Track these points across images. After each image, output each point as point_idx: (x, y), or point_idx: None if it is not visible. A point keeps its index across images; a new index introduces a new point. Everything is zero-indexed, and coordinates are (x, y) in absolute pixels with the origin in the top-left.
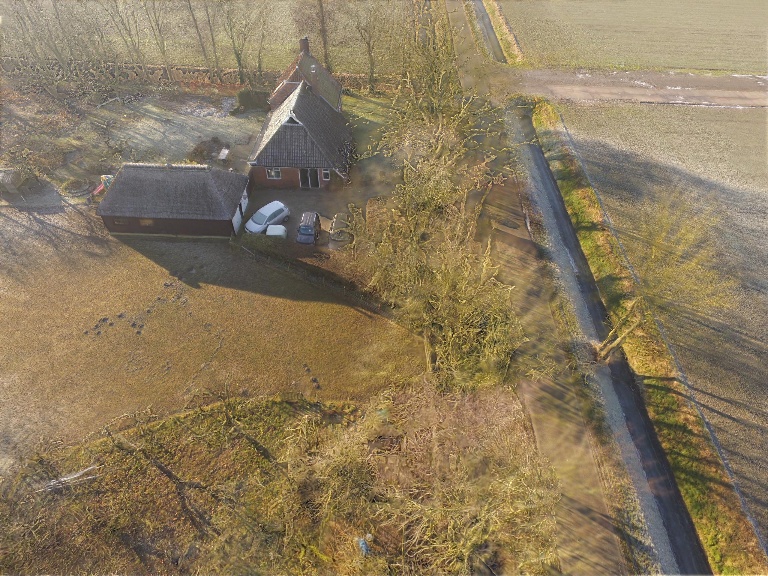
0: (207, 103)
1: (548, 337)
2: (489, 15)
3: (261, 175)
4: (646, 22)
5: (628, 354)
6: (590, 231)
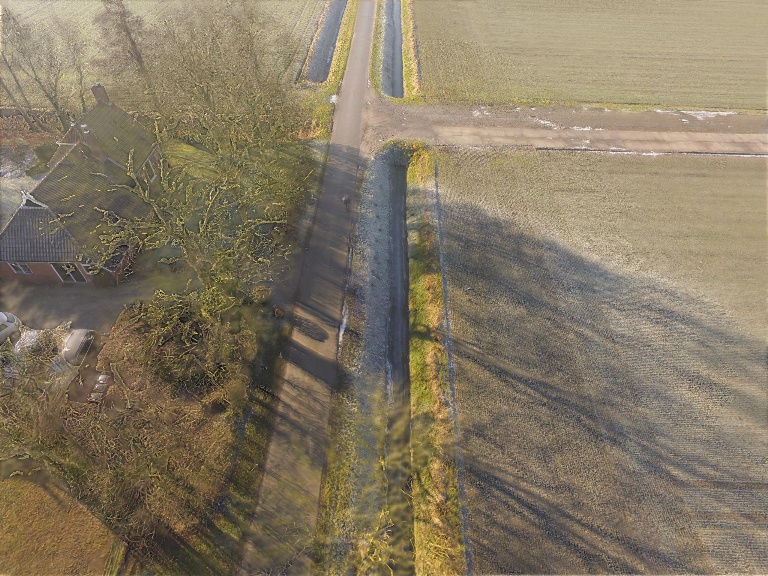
0: (7, 158)
1: (299, 534)
2: (403, 36)
3: (5, 269)
4: (573, 44)
5: (417, 551)
6: (422, 340)
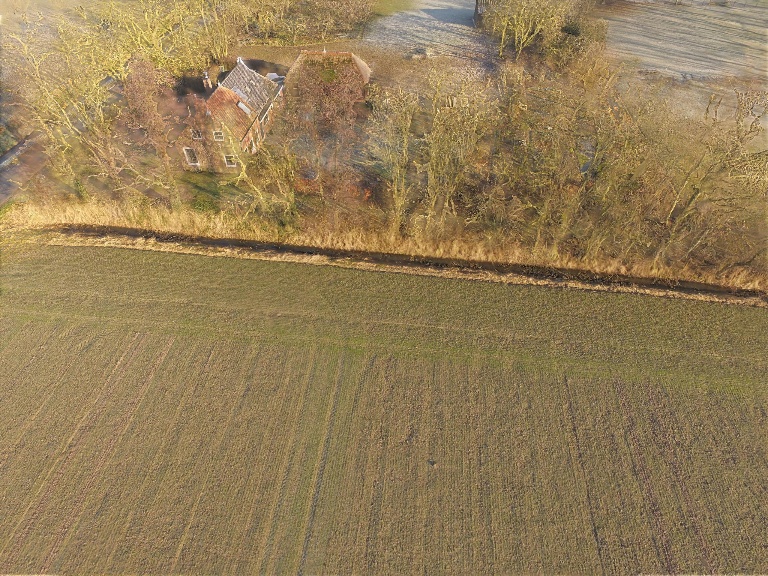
0: None
1: None
2: None
3: None
4: None
5: None
6: None
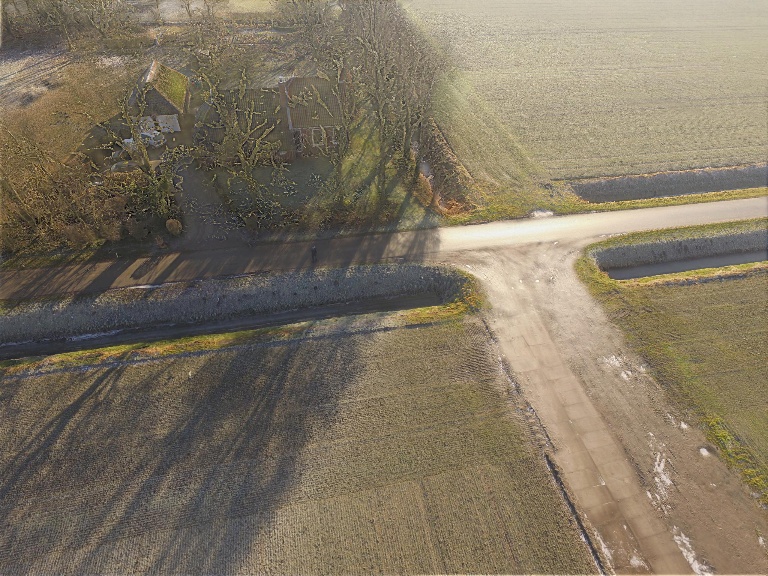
0: None
1: None
2: None
3: None
4: None
5: None
6: (130, 347)
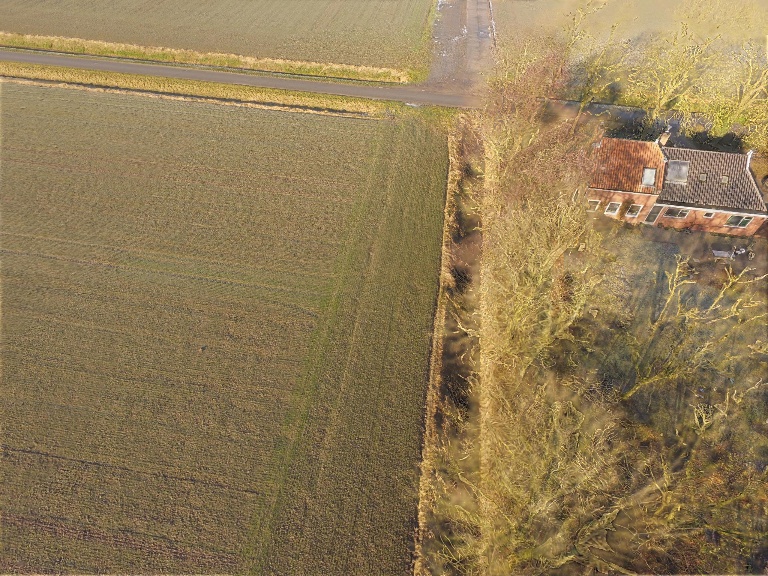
0: None
1: None
2: (237, 67)
3: None
4: (313, 6)
5: None
6: None
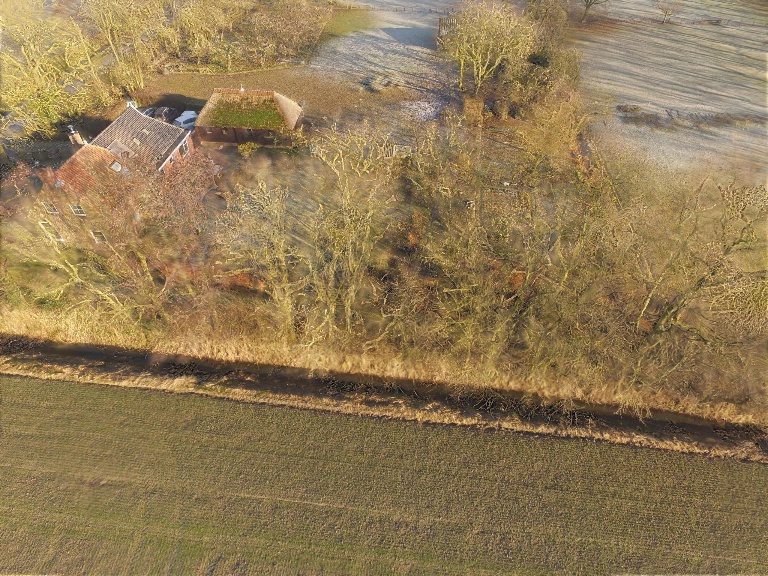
0: None
1: None
2: None
3: None
4: None
5: None
6: None
